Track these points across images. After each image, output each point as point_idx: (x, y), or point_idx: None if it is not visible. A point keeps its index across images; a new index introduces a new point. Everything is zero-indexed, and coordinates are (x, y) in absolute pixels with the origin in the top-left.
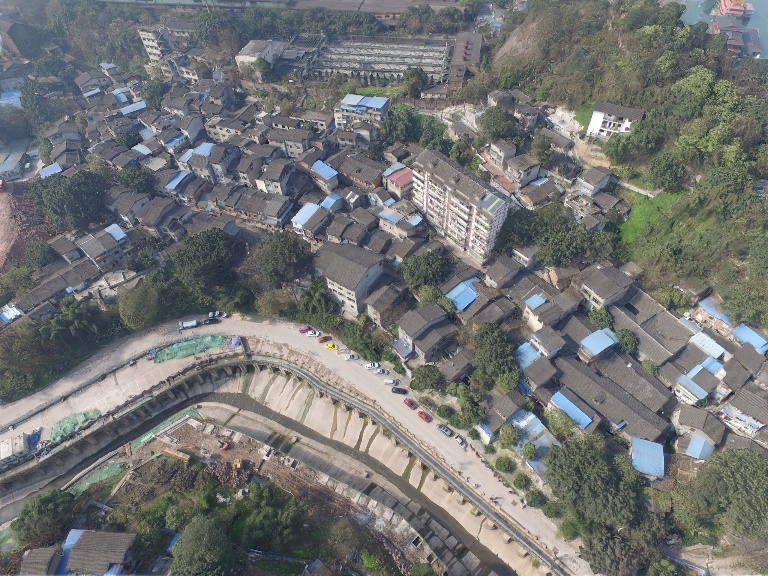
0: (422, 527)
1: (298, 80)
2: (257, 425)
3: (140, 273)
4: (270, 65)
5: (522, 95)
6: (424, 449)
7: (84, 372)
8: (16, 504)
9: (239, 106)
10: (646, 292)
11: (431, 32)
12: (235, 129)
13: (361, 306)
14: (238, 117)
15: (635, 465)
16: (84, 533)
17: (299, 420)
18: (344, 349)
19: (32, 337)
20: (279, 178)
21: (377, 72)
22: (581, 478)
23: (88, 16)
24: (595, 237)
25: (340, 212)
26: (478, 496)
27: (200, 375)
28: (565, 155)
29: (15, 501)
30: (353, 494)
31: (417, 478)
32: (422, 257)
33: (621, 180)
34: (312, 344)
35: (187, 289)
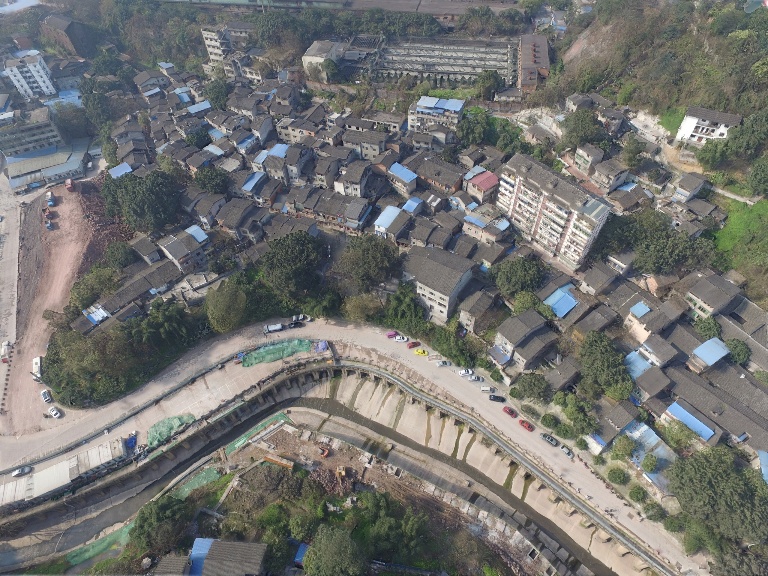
0: (532, 539)
1: (364, 81)
2: (350, 431)
3: (222, 275)
4: (337, 66)
5: (602, 99)
6: (529, 459)
7: (173, 375)
8: (115, 509)
9: (305, 107)
10: (752, 301)
11: (492, 34)
12: (309, 130)
13: (450, 311)
14: (307, 118)
15: (766, 480)
16: (214, 542)
17: (392, 427)
18: (435, 355)
19: (125, 339)
20: (359, 180)
21: (442, 74)
22: (715, 493)
23: (144, 15)
24: (697, 244)
25: (421, 216)
26: (591, 508)
27: (289, 380)
28: (652, 160)
29: (114, 506)
30: (462, 504)
31: (519, 488)
32: (517, 263)
33: (715, 186)
34: (401, 349)
35: (270, 292)
